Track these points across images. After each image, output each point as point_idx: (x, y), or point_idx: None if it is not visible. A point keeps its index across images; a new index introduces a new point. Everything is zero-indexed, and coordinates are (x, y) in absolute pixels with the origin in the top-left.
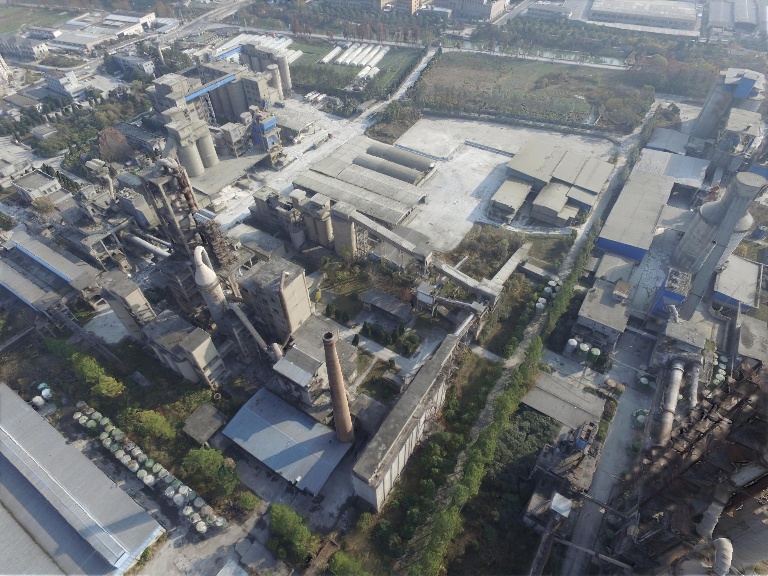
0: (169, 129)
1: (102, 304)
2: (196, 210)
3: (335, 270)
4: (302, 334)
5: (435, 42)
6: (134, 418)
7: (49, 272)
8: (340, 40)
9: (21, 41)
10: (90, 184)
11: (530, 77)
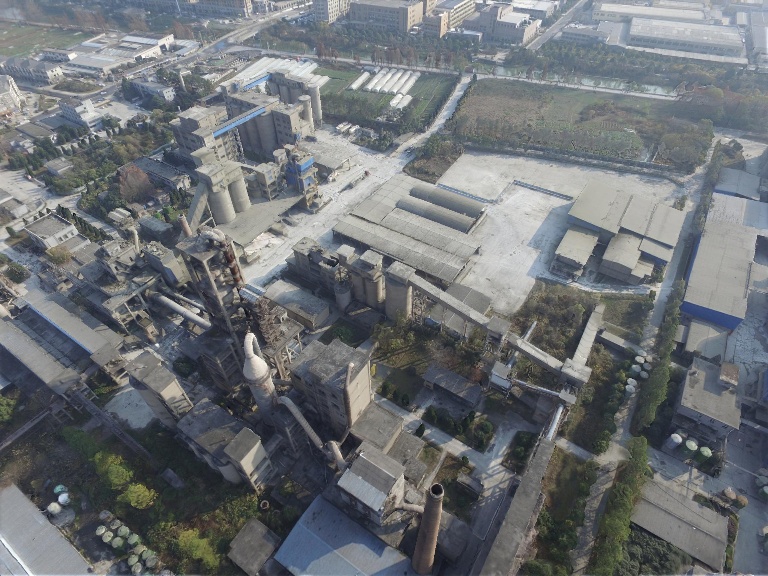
0: (200, 174)
1: (125, 377)
2: (242, 284)
3: (387, 336)
4: (362, 427)
5: (468, 68)
6: (168, 534)
7: (66, 339)
8: (368, 65)
9: (35, 65)
10: (114, 239)
11: (573, 107)
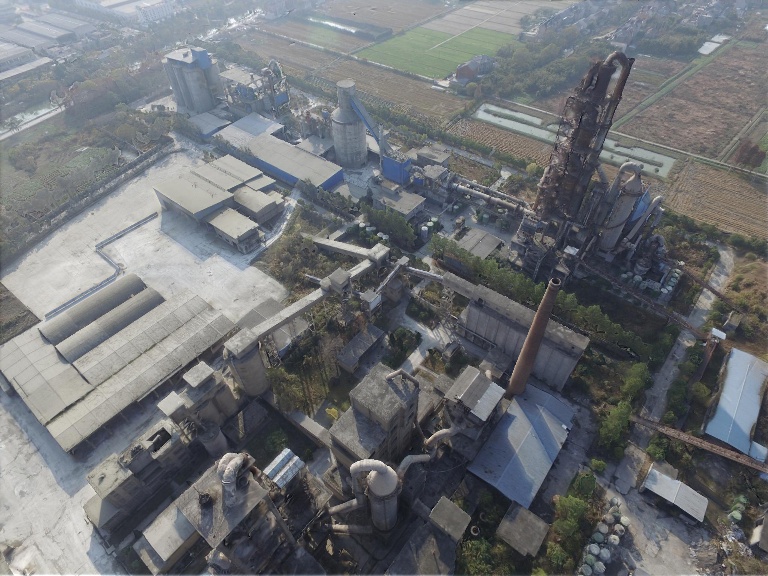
0: None
1: None
2: None
3: None
4: None
5: None
6: None
7: None
8: None
9: None
10: None
11: (0, 170)
